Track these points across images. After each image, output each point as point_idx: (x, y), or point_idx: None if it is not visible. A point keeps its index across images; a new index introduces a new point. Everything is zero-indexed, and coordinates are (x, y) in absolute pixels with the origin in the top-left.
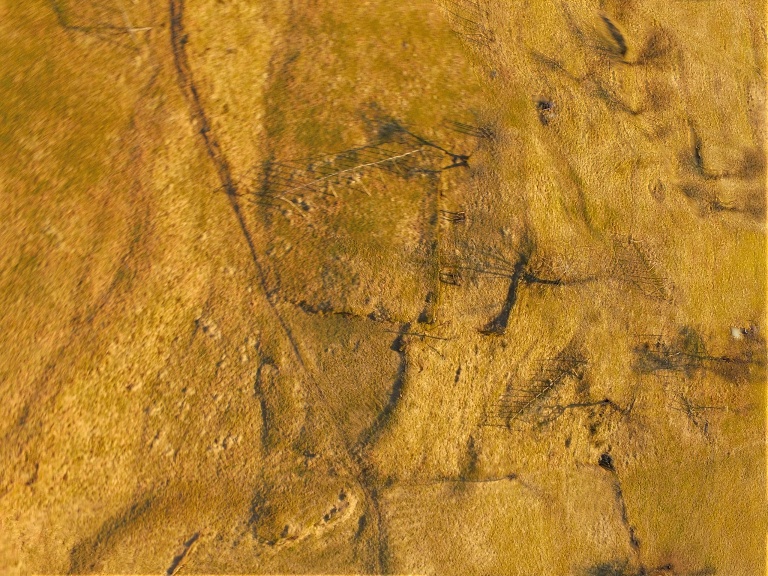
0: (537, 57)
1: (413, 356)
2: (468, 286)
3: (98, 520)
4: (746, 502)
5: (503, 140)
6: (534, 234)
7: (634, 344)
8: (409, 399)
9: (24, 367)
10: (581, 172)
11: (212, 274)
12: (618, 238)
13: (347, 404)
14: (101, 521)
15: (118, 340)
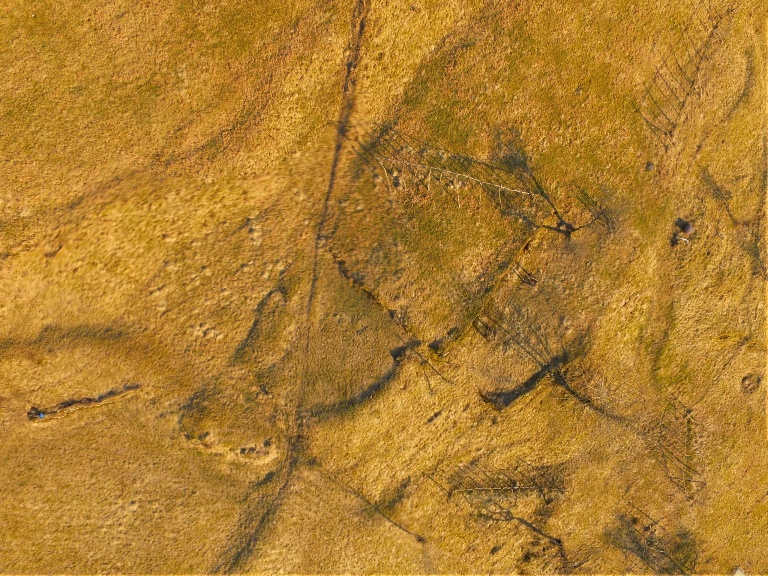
0: (710, 187)
1: (405, 372)
2: (496, 347)
3: (77, 321)
4: None
5: (621, 240)
6: (591, 343)
7: (623, 511)
8: (377, 405)
9: (100, 166)
10: (680, 319)
11: (285, 189)
12: (676, 404)
13: (323, 371)
14: (78, 323)
15: (180, 193)
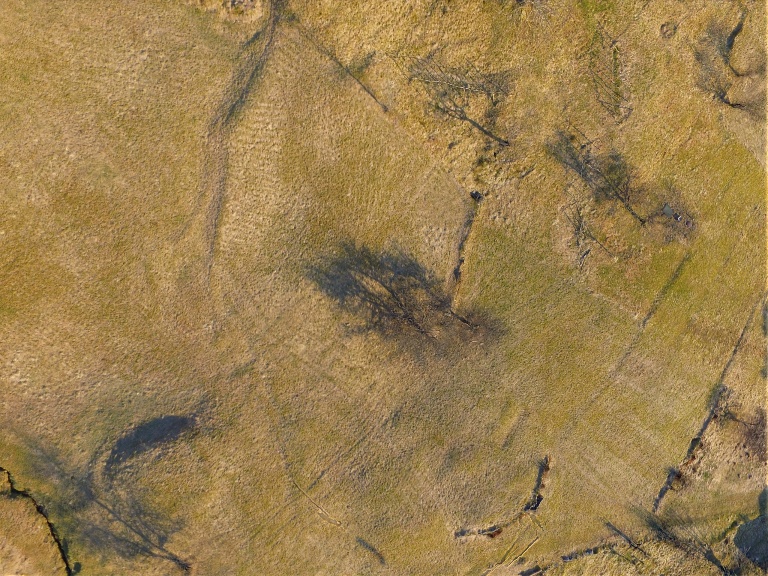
0: None
1: None
2: None
3: None
4: (582, 342)
5: None
6: None
7: (562, 128)
8: None
9: None
10: None
11: None
12: (603, 33)
13: None
14: None
15: None
